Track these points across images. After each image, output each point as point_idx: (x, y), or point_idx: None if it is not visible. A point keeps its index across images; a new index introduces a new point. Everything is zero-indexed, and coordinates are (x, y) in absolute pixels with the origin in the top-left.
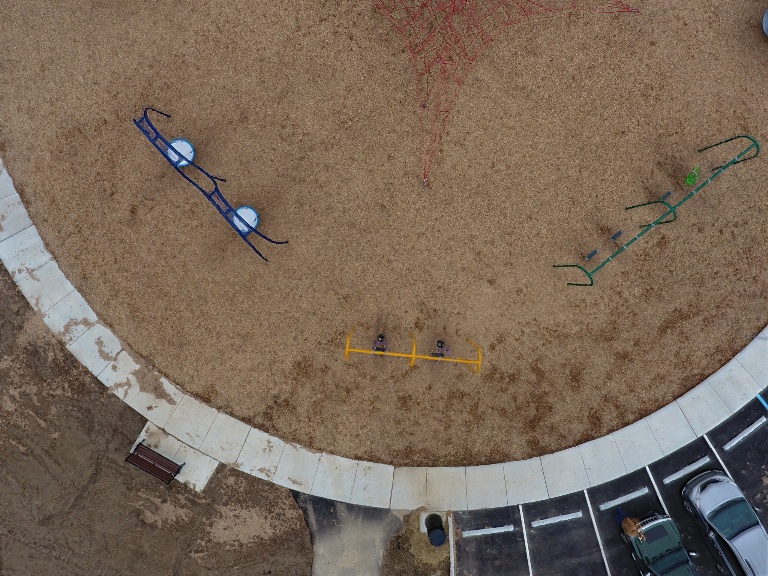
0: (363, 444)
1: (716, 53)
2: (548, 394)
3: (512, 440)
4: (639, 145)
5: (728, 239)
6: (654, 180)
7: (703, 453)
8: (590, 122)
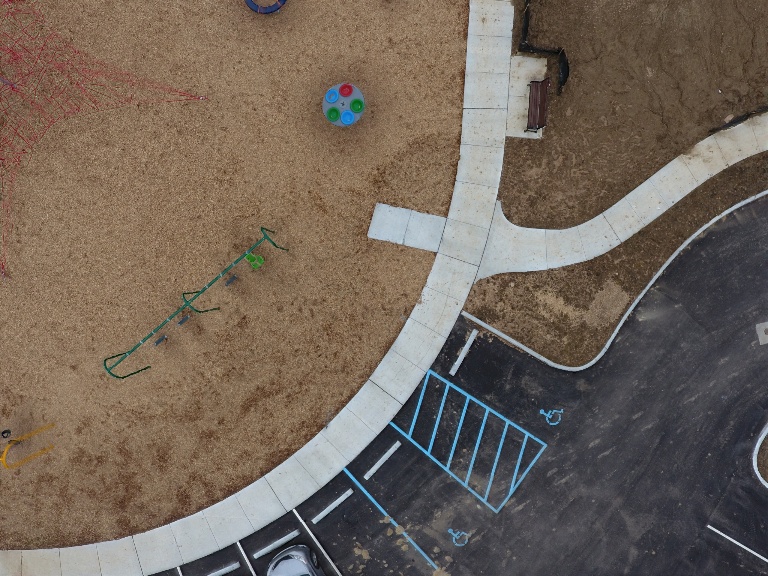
0: None
1: (285, 136)
2: (137, 475)
3: (103, 521)
4: (216, 228)
5: (307, 317)
6: (231, 262)
7: (293, 527)
8: (165, 208)
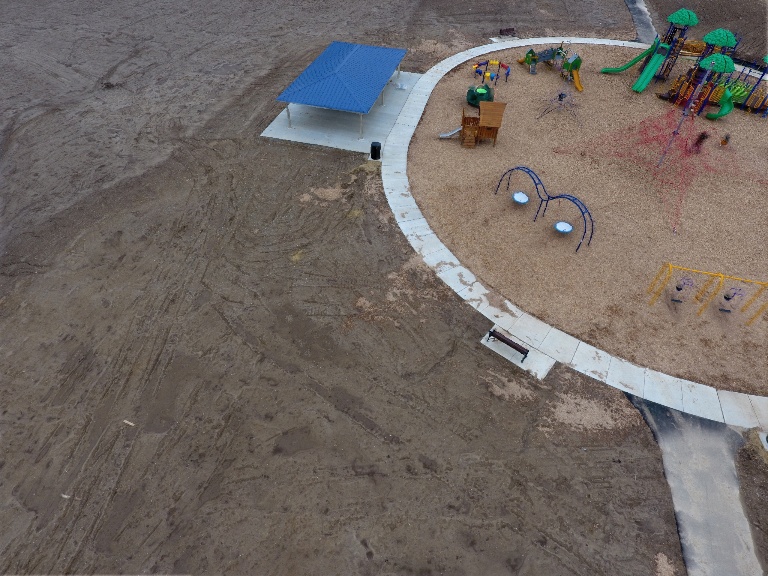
0: (681, 367)
1: None
2: None
3: None
4: None
5: None
6: None
7: None
8: None
